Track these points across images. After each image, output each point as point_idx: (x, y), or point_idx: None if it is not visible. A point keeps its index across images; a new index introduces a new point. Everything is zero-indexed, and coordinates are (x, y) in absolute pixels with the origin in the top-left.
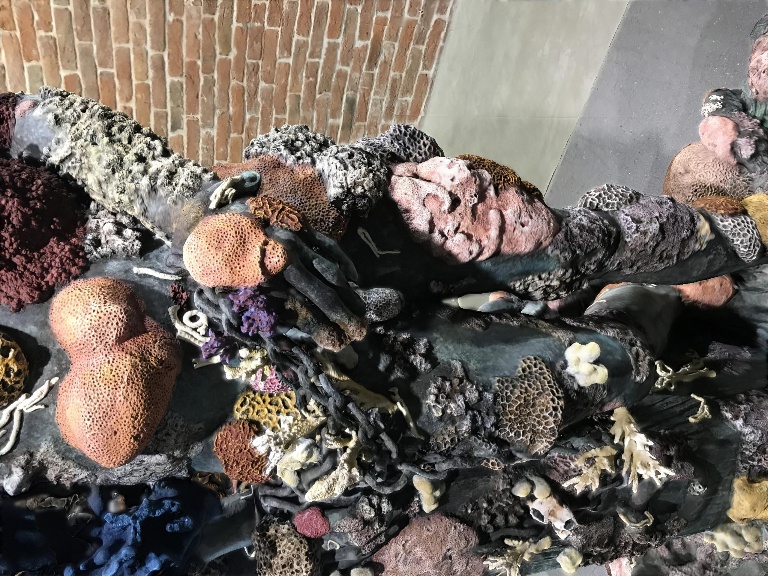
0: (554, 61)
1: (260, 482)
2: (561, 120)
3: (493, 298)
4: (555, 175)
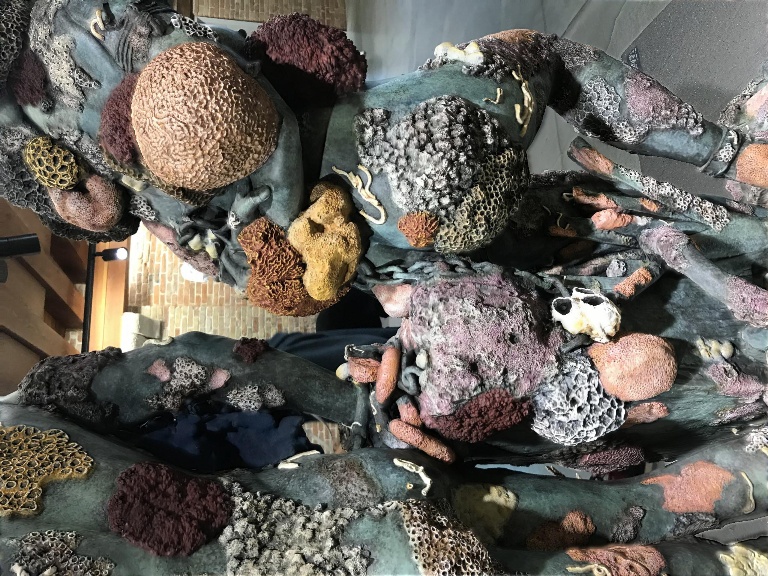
0: None
1: None
2: None
3: None
4: None
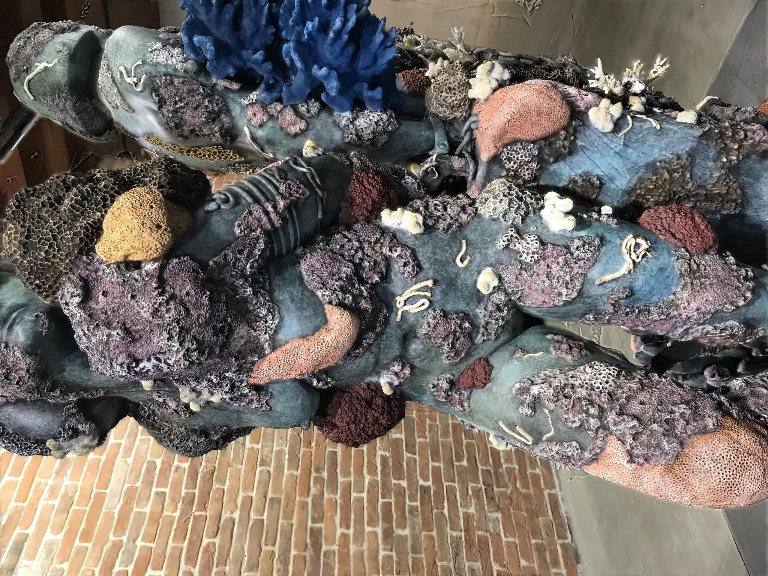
0: (687, 537)
1: (423, 83)
2: (726, 557)
3: (632, 341)
4: (732, 532)
